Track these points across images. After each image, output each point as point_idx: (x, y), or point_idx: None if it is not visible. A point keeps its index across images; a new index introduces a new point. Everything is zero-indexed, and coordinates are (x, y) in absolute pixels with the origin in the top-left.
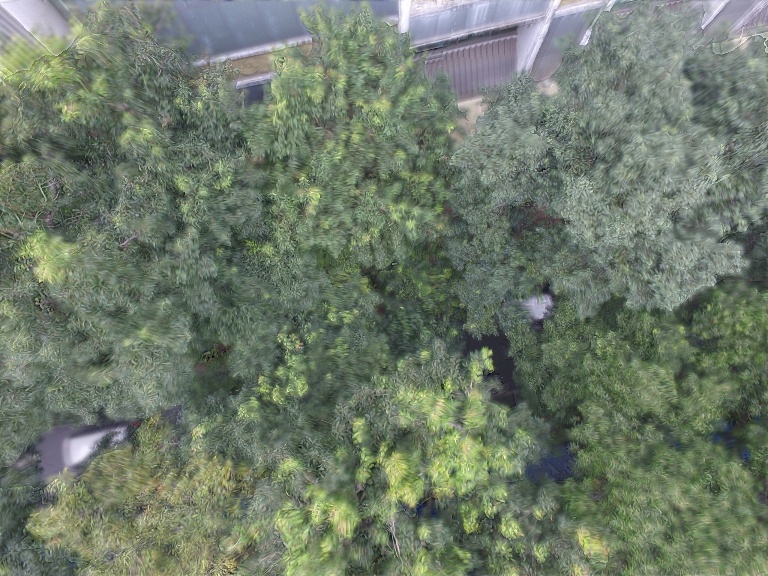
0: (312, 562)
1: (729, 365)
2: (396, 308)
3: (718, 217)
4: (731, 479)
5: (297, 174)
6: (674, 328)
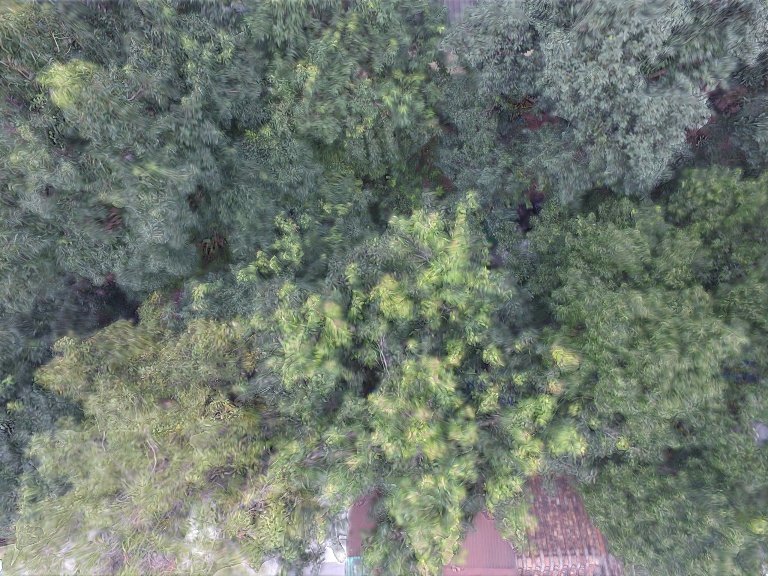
0: (305, 360)
1: (701, 234)
2: (390, 219)
3: (688, 79)
4: (694, 300)
5: (295, 65)
6: (651, 209)
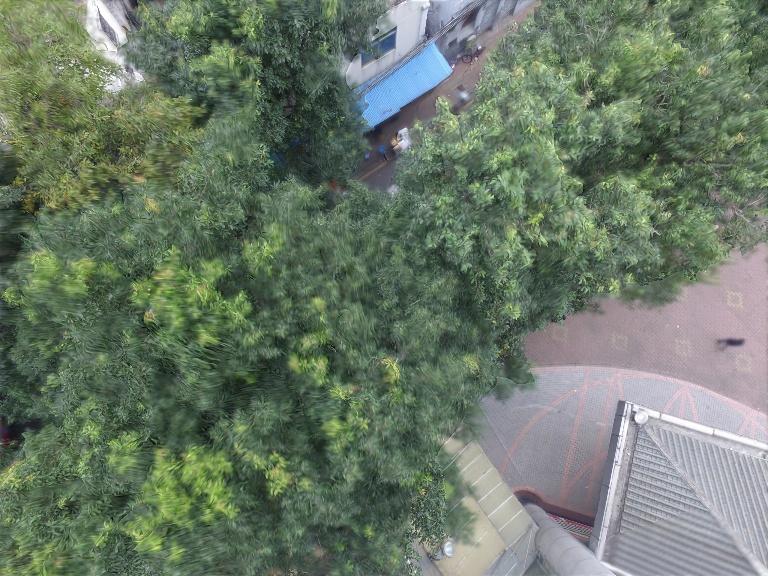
0: None
1: None
2: None
3: None
4: None
5: None
6: None
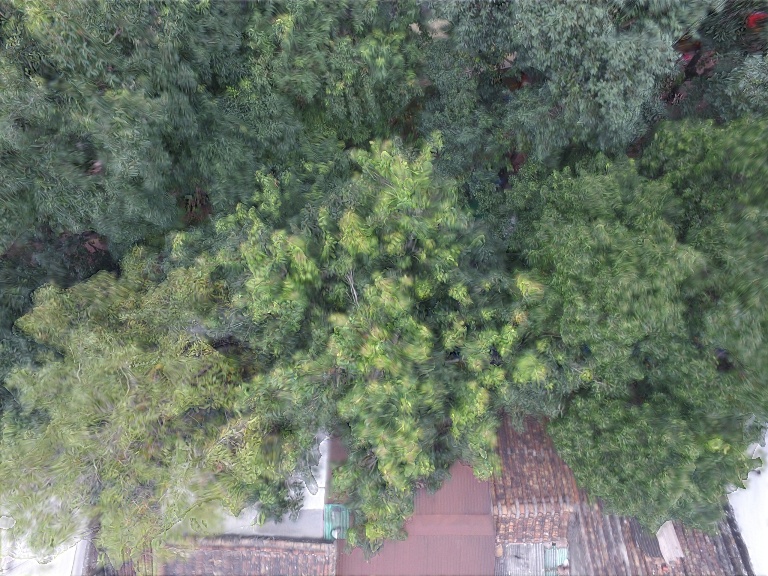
0: (275, 287)
1: (672, 184)
2: None
3: (657, 25)
4: (658, 234)
5: None
6: (625, 162)
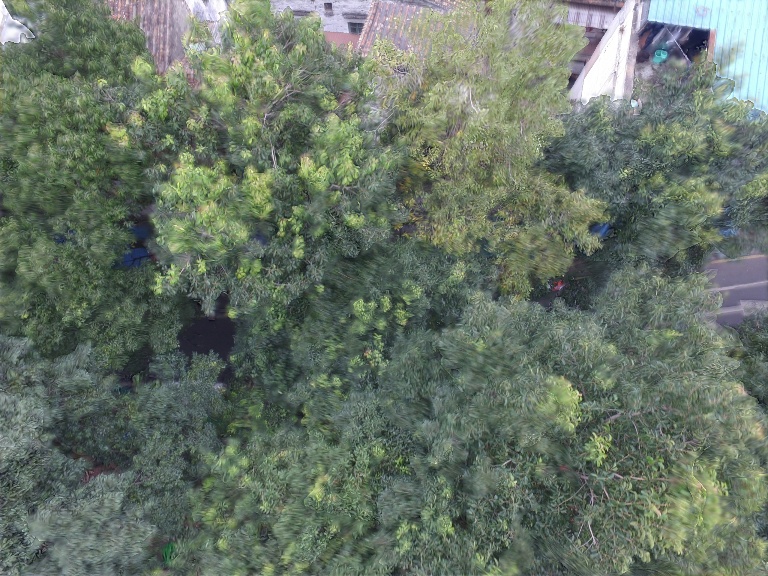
0: (332, 144)
1: None
2: None
3: None
4: None
5: (340, 547)
6: (4, 317)
